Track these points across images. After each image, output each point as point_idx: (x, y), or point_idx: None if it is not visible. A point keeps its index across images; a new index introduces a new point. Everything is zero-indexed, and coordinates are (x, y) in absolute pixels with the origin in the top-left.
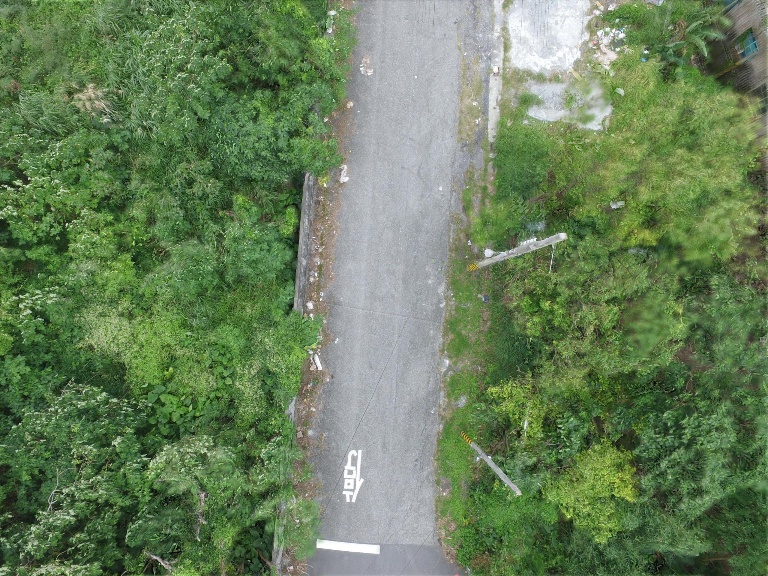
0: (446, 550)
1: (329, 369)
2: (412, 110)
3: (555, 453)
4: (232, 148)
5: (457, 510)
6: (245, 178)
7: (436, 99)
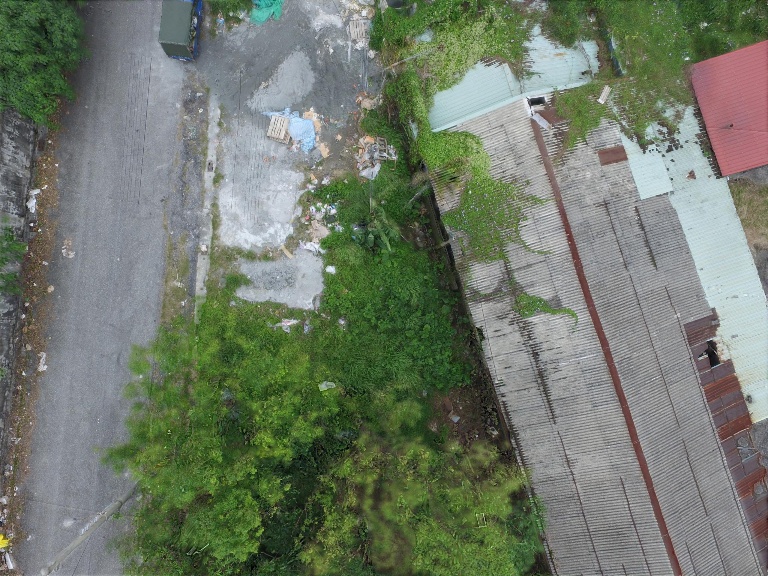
0: None
1: (20, 568)
2: (114, 294)
3: None
4: None
5: None
6: None
7: (139, 282)
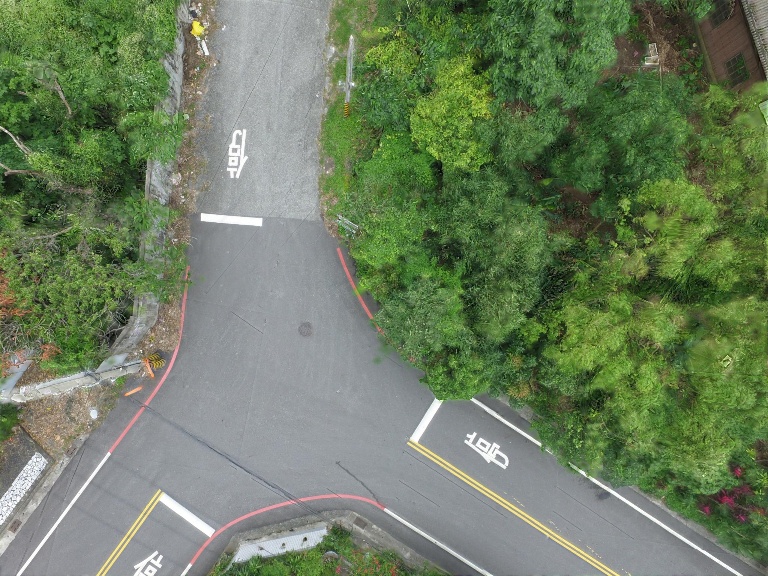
0: (328, 225)
1: (216, 54)
2: None
3: (416, 78)
4: None
5: (339, 187)
6: None
7: None
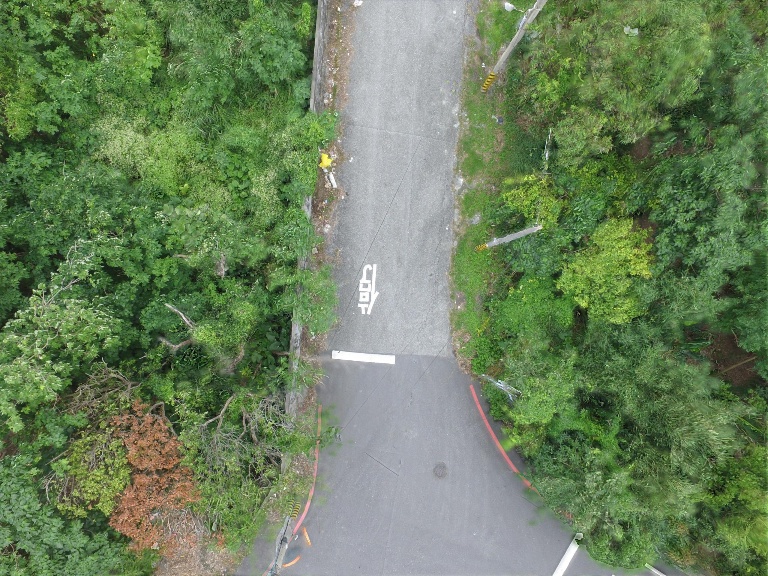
0: (461, 361)
1: (344, 187)
2: None
3: (572, 234)
4: None
5: (471, 322)
6: None
7: None
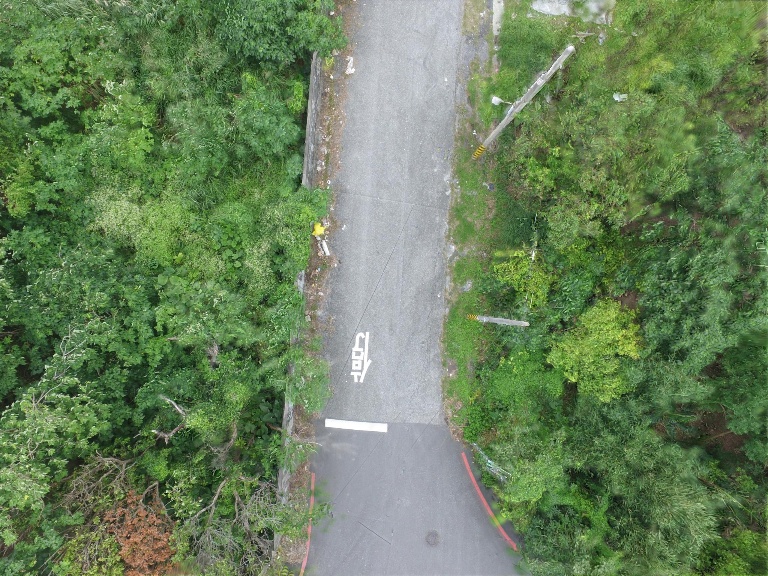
0: (452, 429)
1: (337, 255)
2: (417, 3)
3: (560, 314)
4: (241, 22)
5: (463, 390)
6: (253, 58)
7: None
